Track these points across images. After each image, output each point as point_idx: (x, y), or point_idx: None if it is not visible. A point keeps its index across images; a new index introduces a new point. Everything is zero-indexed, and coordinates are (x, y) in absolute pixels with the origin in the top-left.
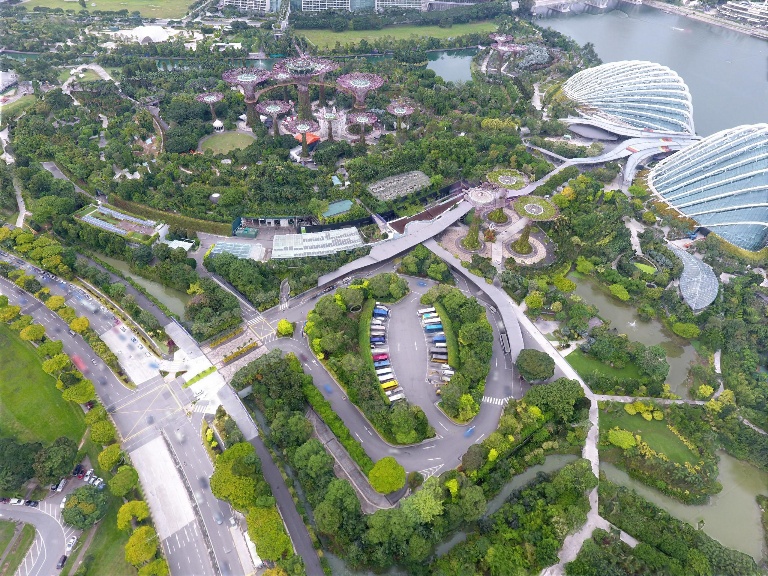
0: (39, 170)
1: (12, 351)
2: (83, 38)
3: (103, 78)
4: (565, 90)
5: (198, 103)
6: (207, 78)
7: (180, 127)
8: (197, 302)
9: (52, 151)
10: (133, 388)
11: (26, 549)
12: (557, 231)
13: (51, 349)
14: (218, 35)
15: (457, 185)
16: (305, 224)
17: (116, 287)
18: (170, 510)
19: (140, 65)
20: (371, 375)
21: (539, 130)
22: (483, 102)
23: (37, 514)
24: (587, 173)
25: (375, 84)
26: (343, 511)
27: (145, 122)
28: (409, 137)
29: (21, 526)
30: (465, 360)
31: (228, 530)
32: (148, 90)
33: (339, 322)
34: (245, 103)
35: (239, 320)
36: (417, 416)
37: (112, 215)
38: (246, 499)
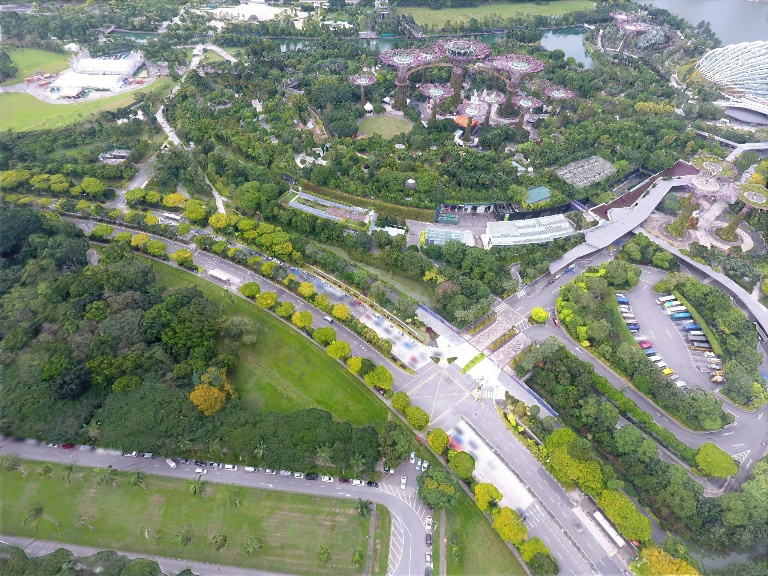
0: (225, 155)
1: (279, 337)
2: (189, 16)
3: (226, 59)
4: (702, 72)
5: (343, 85)
6: (334, 59)
7: (338, 110)
8: (450, 289)
9: (226, 135)
10: (413, 374)
11: (389, 527)
12: (758, 218)
13: (328, 335)
14: (323, 13)
15: (636, 171)
16: (508, 211)
17: (361, 274)
18: (506, 492)
19: (266, 45)
20: (651, 363)
21: (696, 114)
22: (625, 84)
23: (382, 494)
24: (767, 159)
25: (534, 66)
26: (697, 495)
27: (302, 105)
28: (568, 121)
29: (373, 506)
30: (738, 348)
31: (571, 511)
32: (282, 71)
33: (598, 310)
34: (386, 85)
35: (490, 307)
36: (716, 403)
37: (317, 201)
38: (597, 482)
